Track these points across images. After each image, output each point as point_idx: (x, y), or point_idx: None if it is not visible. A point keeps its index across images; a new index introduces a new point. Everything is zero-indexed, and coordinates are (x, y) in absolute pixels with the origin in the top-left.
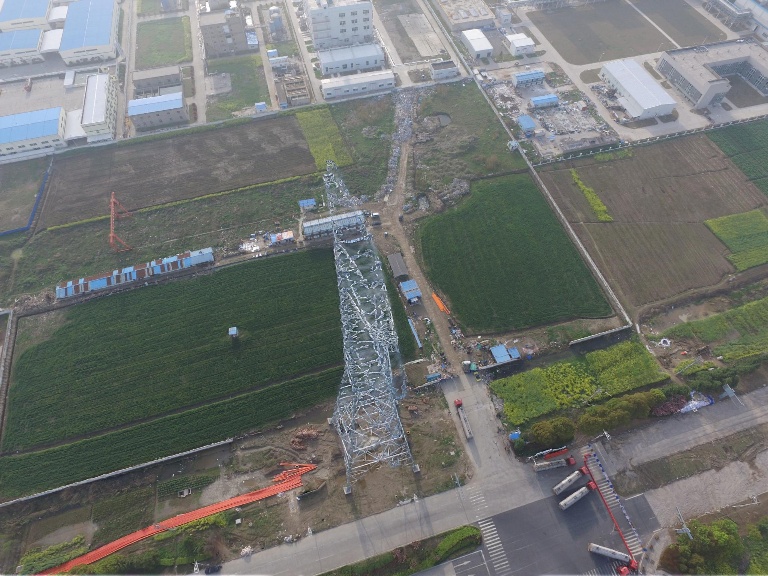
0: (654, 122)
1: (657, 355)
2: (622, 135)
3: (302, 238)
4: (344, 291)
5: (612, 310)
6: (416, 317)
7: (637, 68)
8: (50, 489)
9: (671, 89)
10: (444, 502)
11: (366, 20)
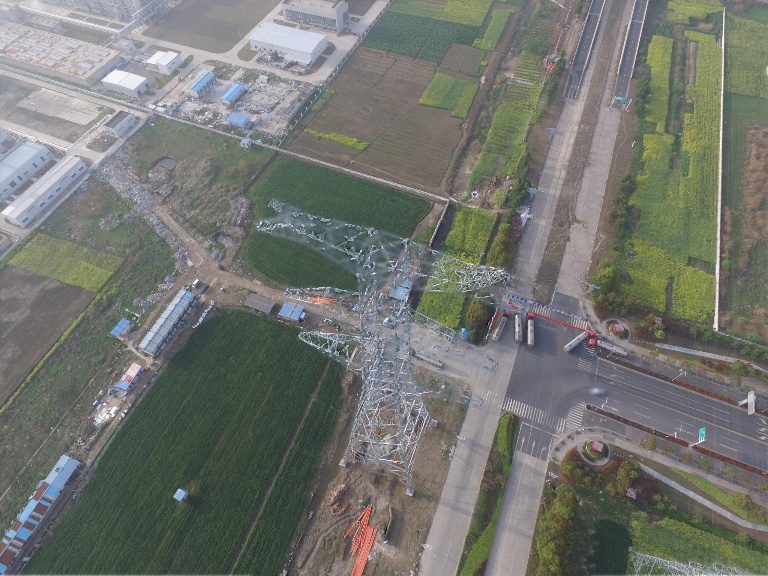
0: (324, 59)
1: (479, 206)
2: (313, 82)
3: (151, 360)
4: (301, 335)
5: (429, 202)
6: (317, 326)
7: (275, 27)
8: None
9: (310, 29)
10: (472, 422)
11: None
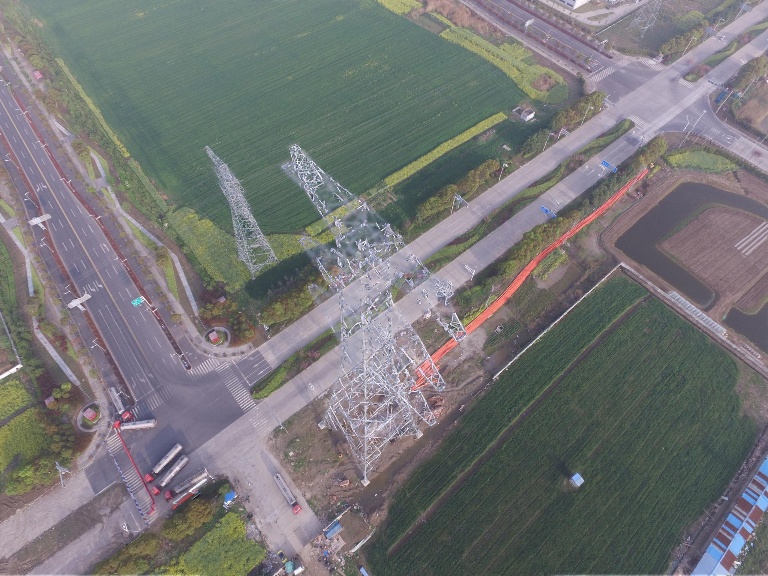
0: None
1: None
2: None
3: None
4: None
5: None
6: None
7: None
8: (593, 291)
9: None
10: (289, 408)
11: None
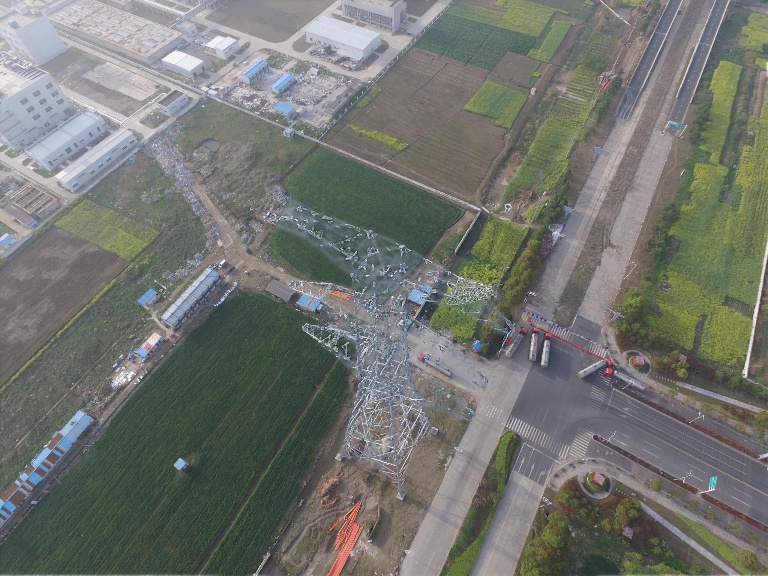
0: (375, 56)
1: (511, 219)
2: (362, 78)
3: (171, 331)
4: (305, 326)
5: (461, 209)
6: (333, 320)
7: (332, 21)
8: None
9: (367, 26)
10: (473, 435)
11: (55, 94)
